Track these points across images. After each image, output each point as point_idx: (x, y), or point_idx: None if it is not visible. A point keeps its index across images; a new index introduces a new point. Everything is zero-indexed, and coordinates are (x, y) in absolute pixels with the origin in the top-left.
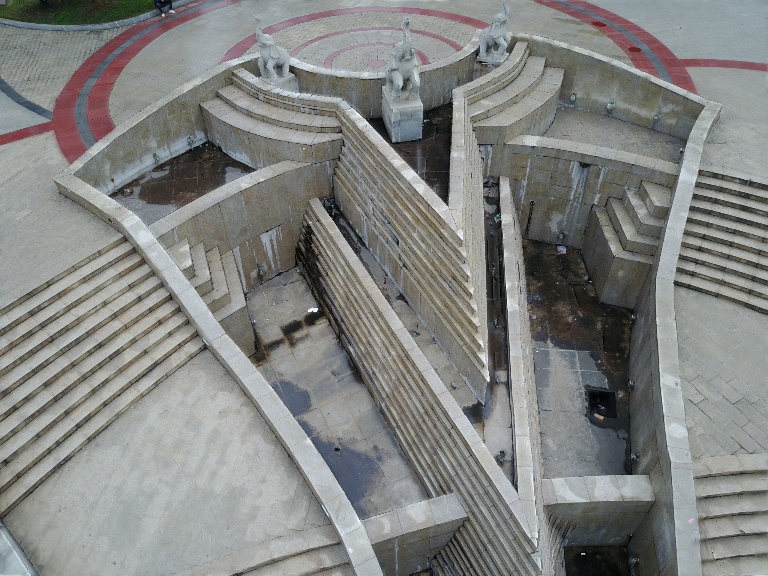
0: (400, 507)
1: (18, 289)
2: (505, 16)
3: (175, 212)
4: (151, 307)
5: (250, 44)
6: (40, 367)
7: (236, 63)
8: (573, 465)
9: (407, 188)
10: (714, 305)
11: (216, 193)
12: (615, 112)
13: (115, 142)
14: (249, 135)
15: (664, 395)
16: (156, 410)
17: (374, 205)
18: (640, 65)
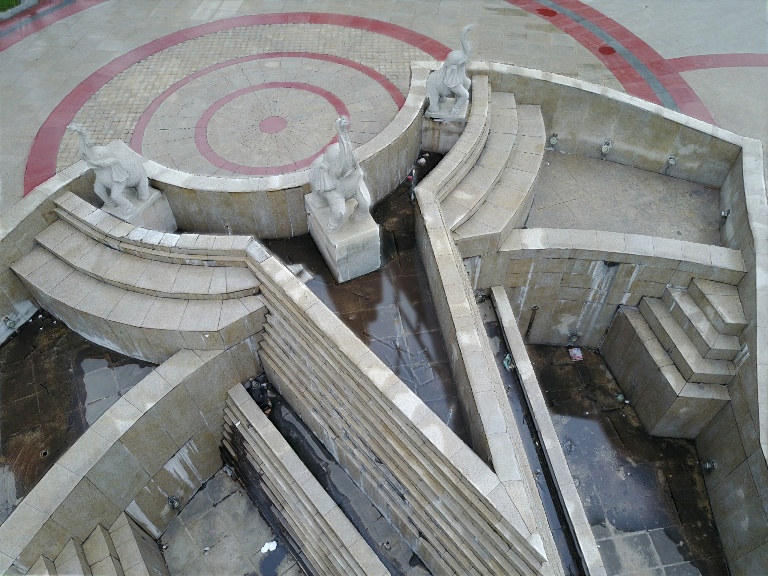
0: None
1: None
2: (464, 56)
3: (9, 521)
4: None
5: (71, 111)
6: None
7: (56, 187)
8: None
9: (409, 428)
10: None
11: (76, 455)
12: (612, 154)
13: None
14: (108, 322)
15: None
16: None
17: (345, 424)
18: (624, 77)
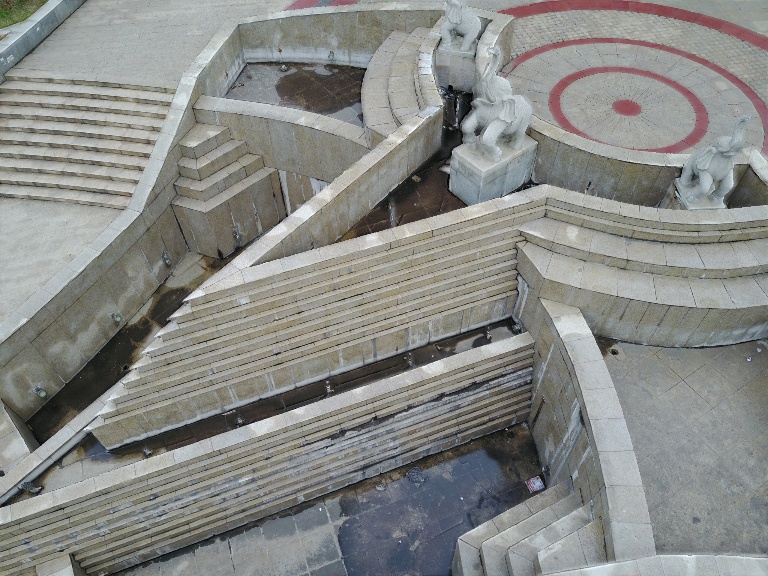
0: None
1: (105, 75)
2: (727, 145)
3: (236, 101)
4: (146, 153)
5: (572, 7)
6: (60, 132)
7: None
8: None
9: None
10: None
11: (278, 110)
12: None
13: (293, 19)
14: None
15: None
16: (66, 217)
17: None
18: None
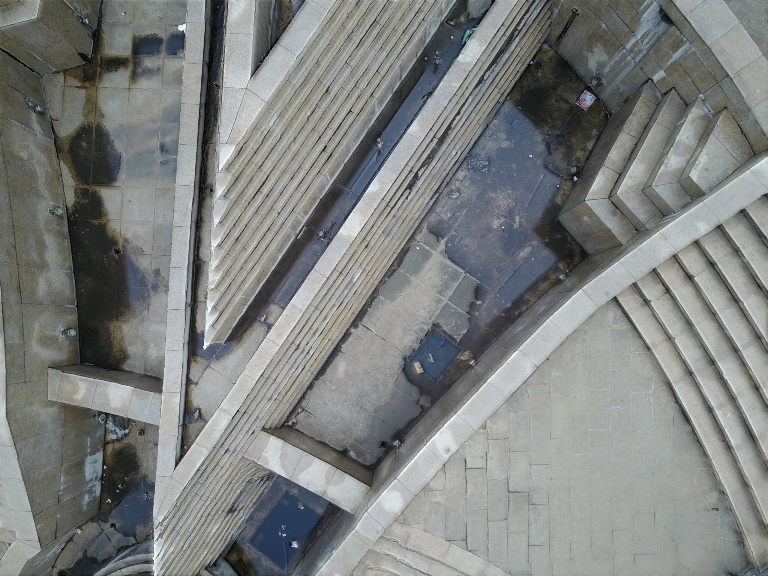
0: (145, 350)
1: None
2: None
3: None
4: None
5: None
6: None
7: None
8: (345, 404)
9: None
10: (631, 359)
11: None
12: None
13: None
14: None
15: (420, 456)
16: None
17: None
18: None
